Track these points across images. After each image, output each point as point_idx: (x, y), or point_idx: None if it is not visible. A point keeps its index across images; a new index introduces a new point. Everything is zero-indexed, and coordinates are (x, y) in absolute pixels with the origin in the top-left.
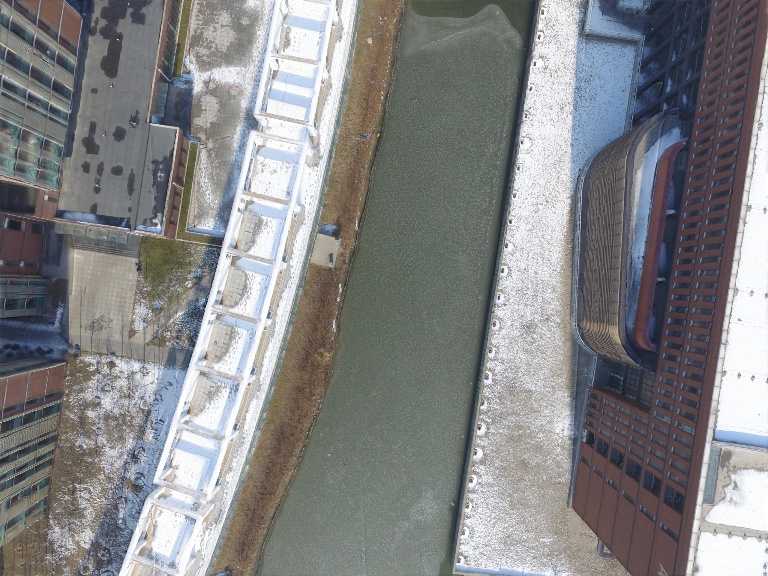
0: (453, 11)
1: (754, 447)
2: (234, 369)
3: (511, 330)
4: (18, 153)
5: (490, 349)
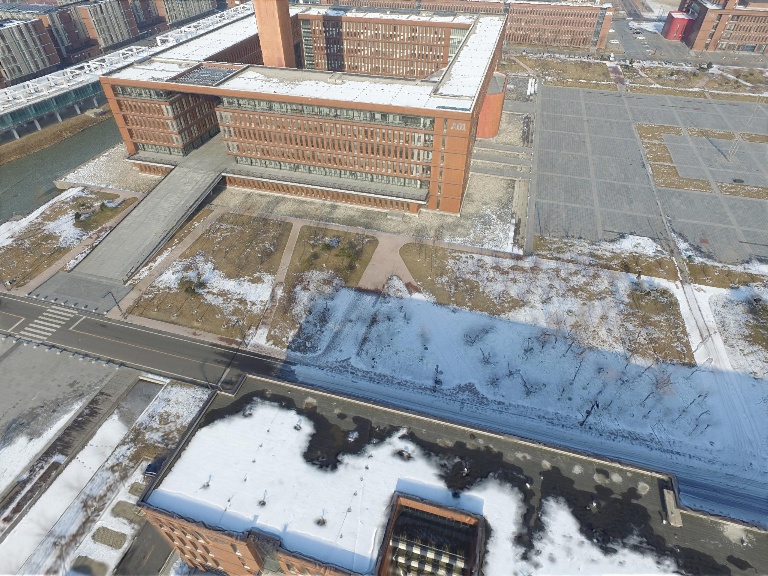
0: None
1: None
2: None
3: None
4: (6, 57)
5: None
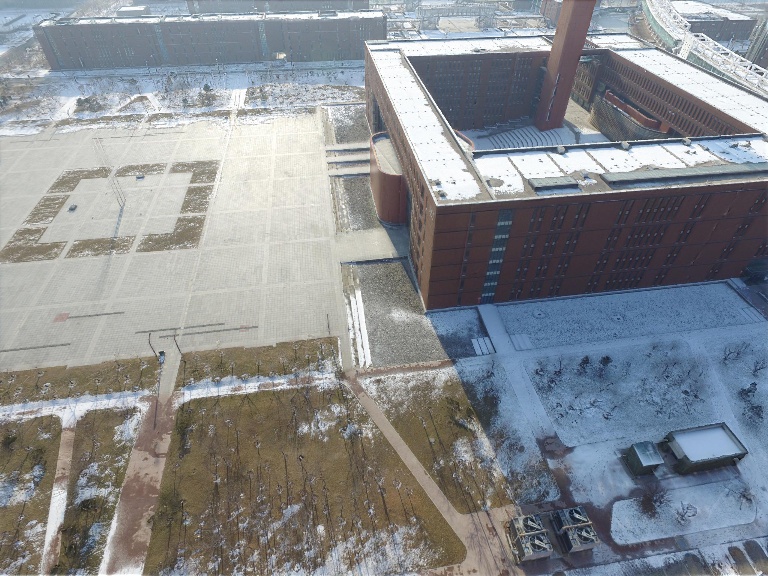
0: None
1: (644, 48)
2: (764, 87)
3: None
4: None
5: None
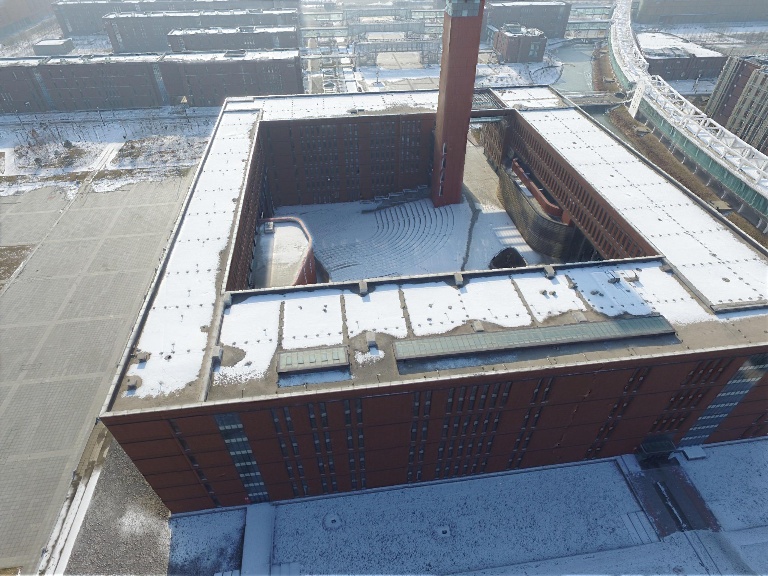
0: None
1: (560, 108)
2: None
3: None
4: None
5: None
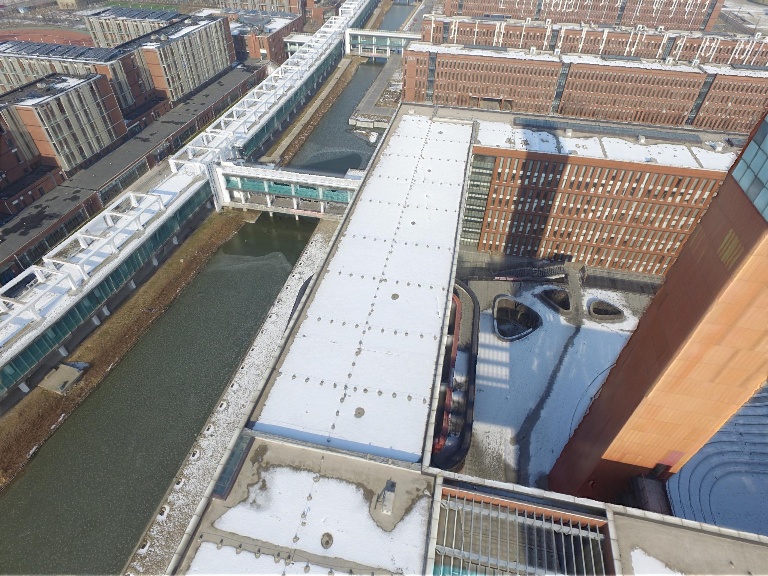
0: (250, 253)
1: (289, 438)
2: None
3: (209, 461)
4: None
5: (180, 481)
